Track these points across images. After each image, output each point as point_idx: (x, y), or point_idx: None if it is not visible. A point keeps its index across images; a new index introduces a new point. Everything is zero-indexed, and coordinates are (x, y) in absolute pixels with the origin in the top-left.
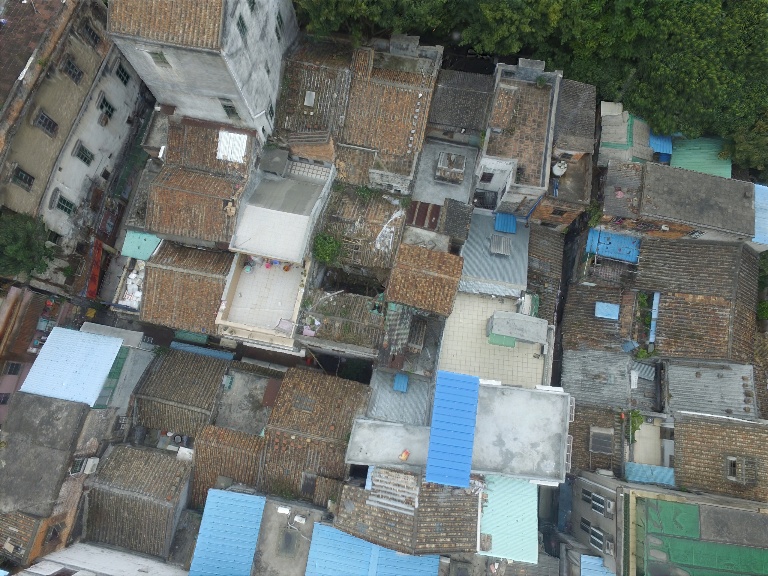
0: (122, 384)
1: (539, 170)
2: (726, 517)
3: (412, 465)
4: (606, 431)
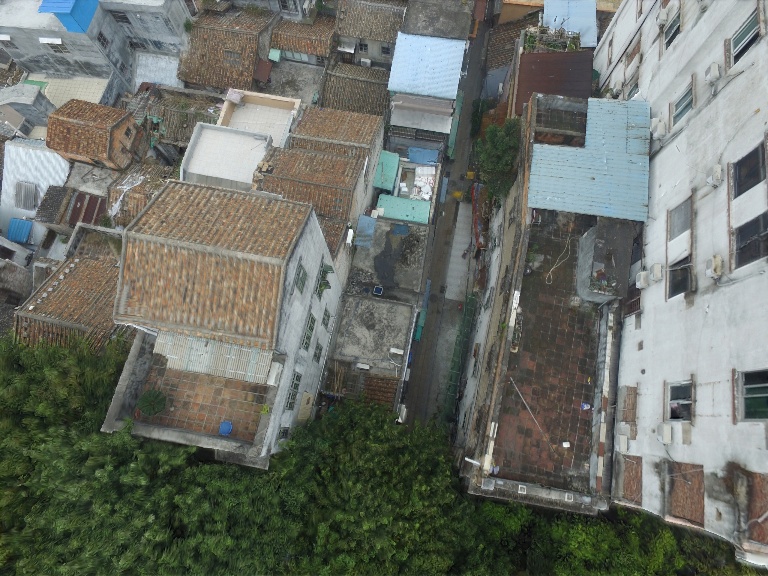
0: None
1: None
2: None
3: None
4: None
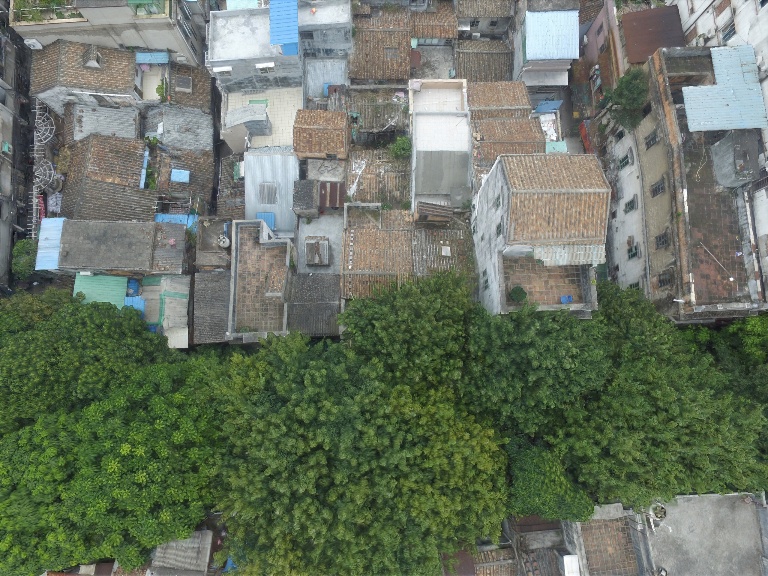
0: (520, 45)
1: (241, 246)
2: (111, 1)
3: (307, 3)
4: (181, 89)
